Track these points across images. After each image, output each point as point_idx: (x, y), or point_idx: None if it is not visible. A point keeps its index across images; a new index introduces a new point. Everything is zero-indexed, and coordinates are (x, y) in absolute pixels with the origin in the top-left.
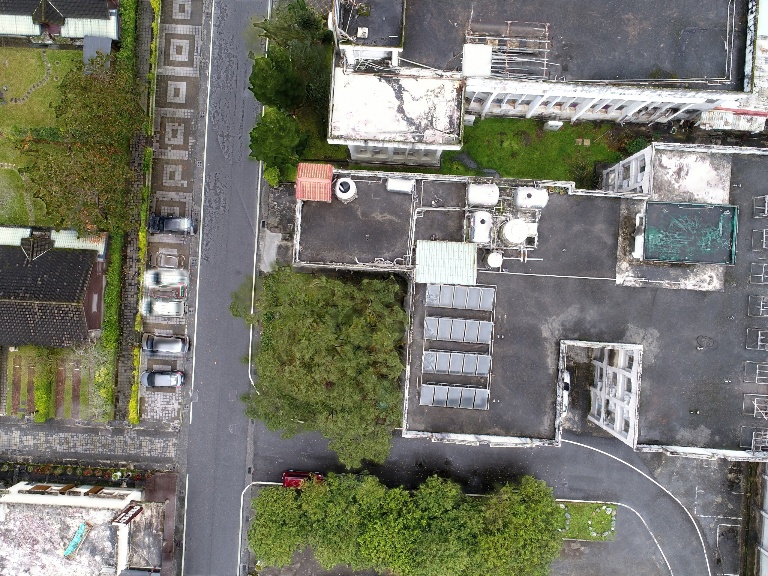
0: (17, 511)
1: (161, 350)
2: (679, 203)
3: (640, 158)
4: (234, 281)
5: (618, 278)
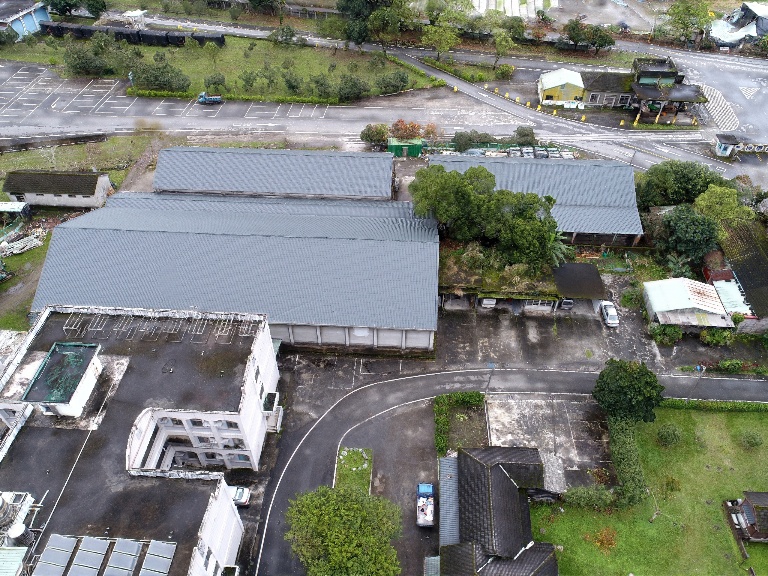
0: None
1: None
2: (34, 379)
3: (6, 416)
4: None
5: (92, 428)
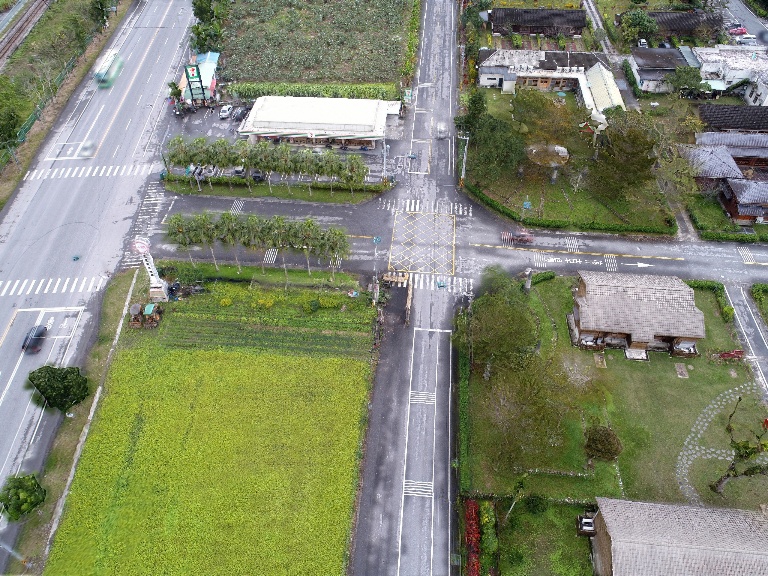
0: (723, 51)
1: (748, 37)
2: None
3: None
4: (762, 32)
5: None
